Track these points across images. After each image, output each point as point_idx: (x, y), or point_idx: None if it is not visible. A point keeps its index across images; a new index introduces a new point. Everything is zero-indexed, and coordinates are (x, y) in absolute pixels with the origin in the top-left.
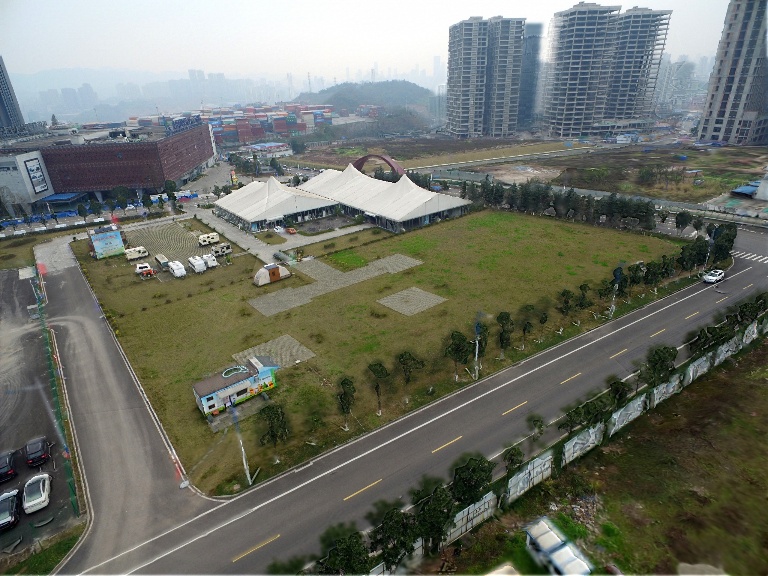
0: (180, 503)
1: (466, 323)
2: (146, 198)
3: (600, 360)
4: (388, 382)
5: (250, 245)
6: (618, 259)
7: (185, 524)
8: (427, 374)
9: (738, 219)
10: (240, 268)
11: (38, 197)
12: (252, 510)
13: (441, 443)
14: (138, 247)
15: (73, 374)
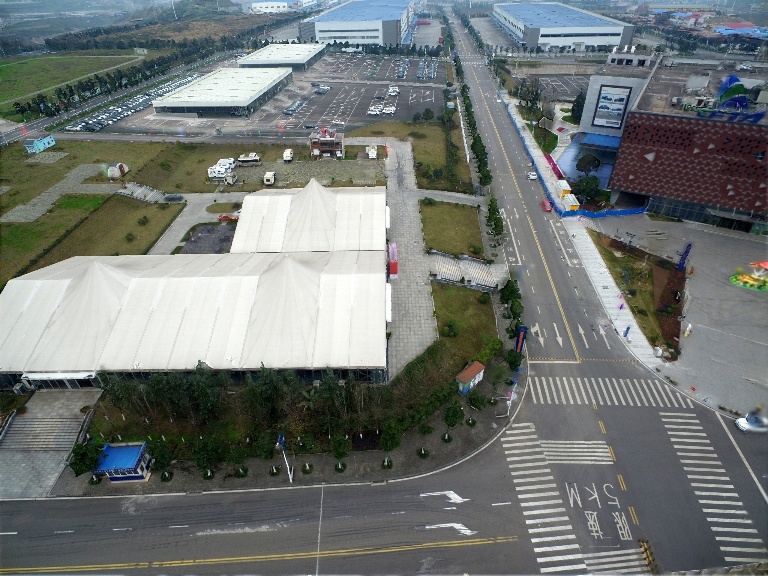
0: (26, 138)
1: None
2: (481, 162)
3: None
4: None
5: (233, 196)
6: None
7: (19, 138)
8: None
9: None
10: (192, 185)
11: (594, 130)
12: None
13: None
14: (289, 152)
15: (135, 135)
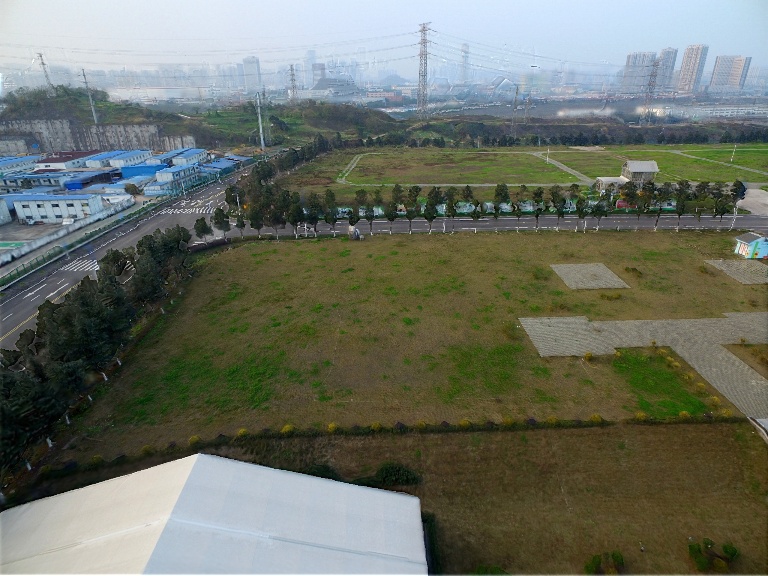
0: None
1: (557, 246)
2: None
3: (497, 223)
4: (644, 238)
5: None
6: (320, 252)
7: (760, 228)
8: (614, 235)
9: (48, 257)
10: None
11: None
12: (726, 226)
13: (624, 221)
14: None
15: None
